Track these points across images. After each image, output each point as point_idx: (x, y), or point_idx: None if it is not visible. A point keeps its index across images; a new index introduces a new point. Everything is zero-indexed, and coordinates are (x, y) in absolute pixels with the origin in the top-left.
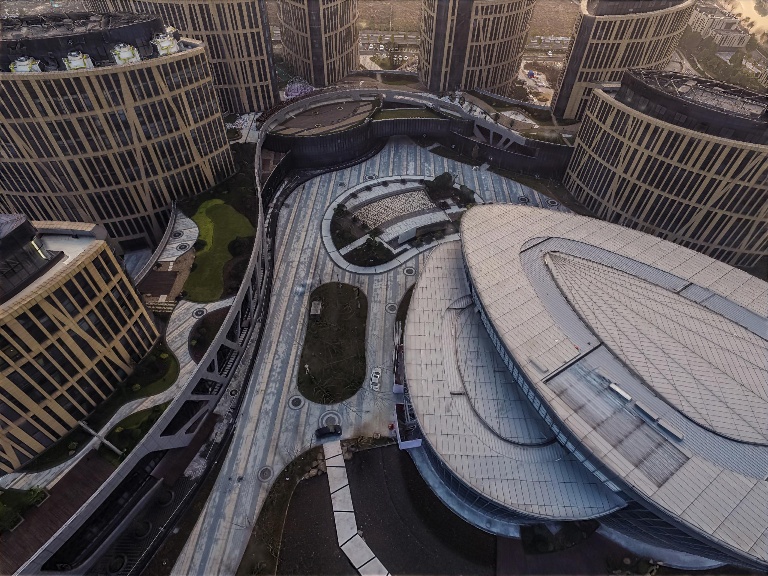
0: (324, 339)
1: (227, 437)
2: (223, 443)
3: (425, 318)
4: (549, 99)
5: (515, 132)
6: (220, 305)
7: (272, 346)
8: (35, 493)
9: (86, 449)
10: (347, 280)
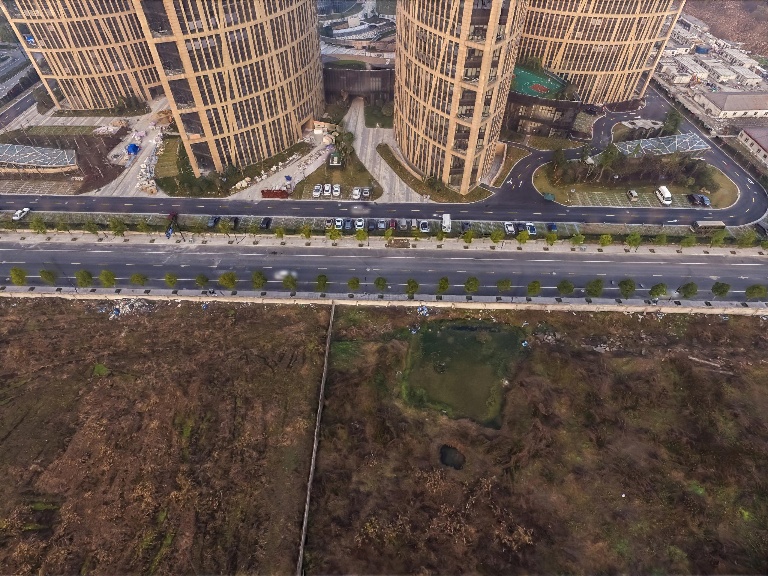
0: (393, 3)
1: None
2: None
3: None
4: (157, 113)
5: None
6: None
7: None
8: None
9: None
10: (386, 15)
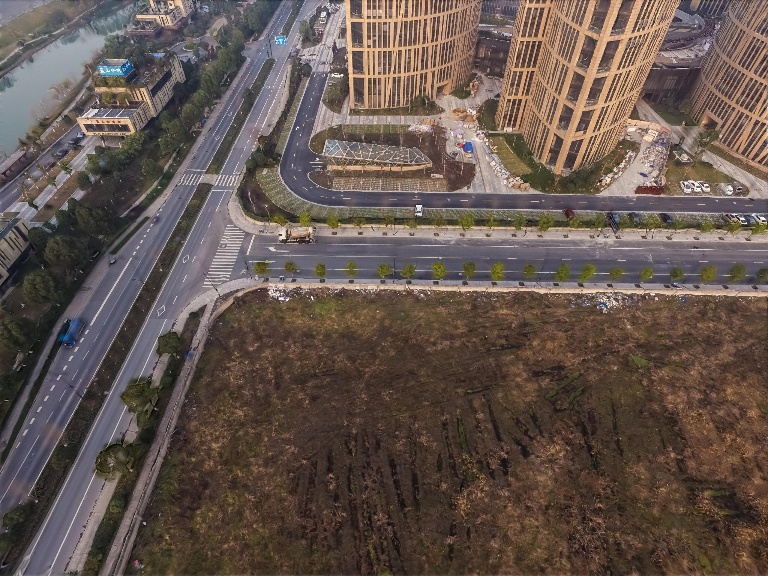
0: None
1: None
2: None
3: None
4: (452, 112)
5: (509, 26)
6: None
7: None
8: None
9: None
10: None
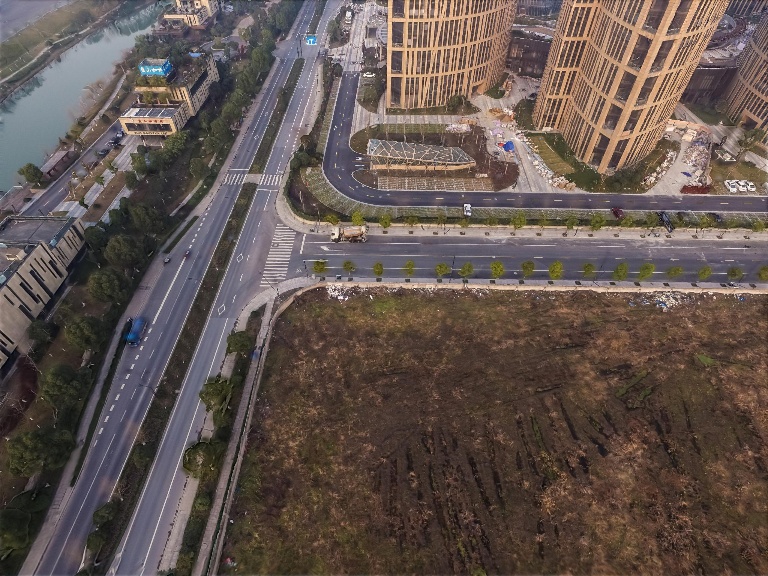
0: None
1: None
2: None
3: None
4: (488, 111)
5: (540, 26)
6: None
7: None
8: None
9: None
10: None
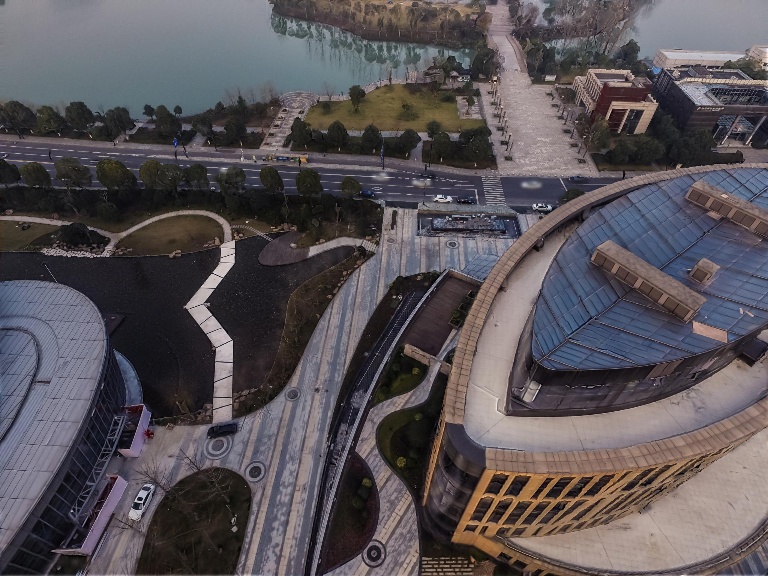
0: None
1: (335, 431)
2: (338, 424)
3: (2, 507)
4: None
5: None
6: (343, 574)
7: (284, 573)
8: (454, 313)
9: (440, 358)
10: None
